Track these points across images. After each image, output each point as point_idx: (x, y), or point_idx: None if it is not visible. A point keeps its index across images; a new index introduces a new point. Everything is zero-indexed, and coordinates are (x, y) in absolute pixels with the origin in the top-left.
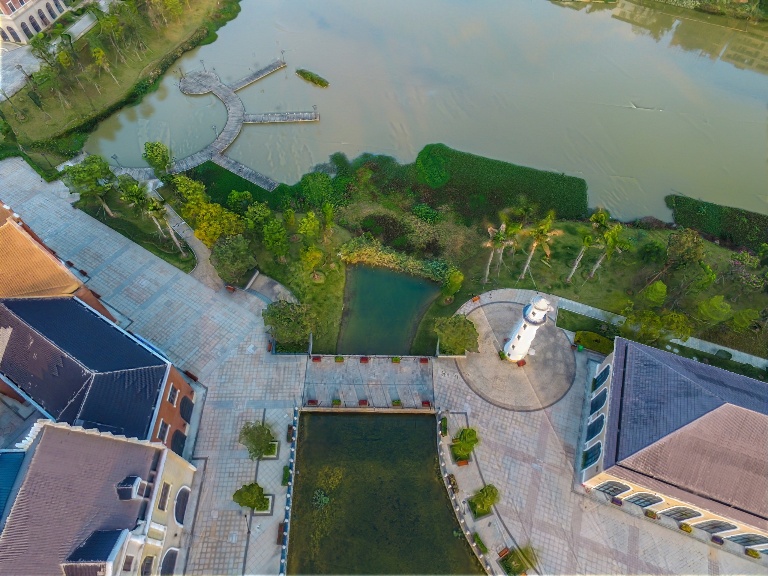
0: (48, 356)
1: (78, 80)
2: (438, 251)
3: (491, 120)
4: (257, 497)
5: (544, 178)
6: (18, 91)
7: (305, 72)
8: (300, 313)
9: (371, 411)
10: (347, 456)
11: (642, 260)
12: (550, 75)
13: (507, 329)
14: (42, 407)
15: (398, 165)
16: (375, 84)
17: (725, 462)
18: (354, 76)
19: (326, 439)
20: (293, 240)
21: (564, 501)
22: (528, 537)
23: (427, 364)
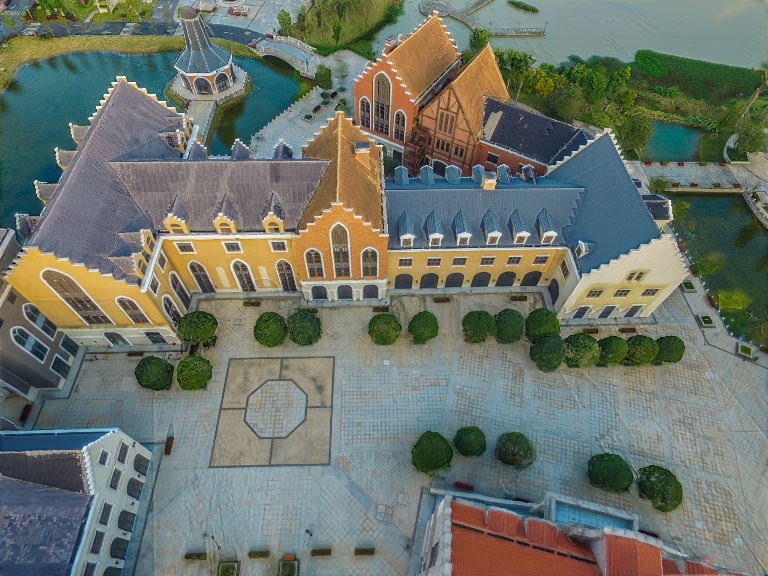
0: (539, 124)
1: (351, 2)
2: (683, 114)
3: (678, 35)
4: None
5: (739, 71)
6: (309, 9)
7: (517, 2)
8: (648, 124)
9: (700, 191)
10: (693, 215)
11: None
12: (710, 6)
13: None
14: (533, 159)
15: (623, 63)
16: (575, 11)
17: None
18: (556, 5)
19: None
20: None
21: None
22: None
23: (724, 167)
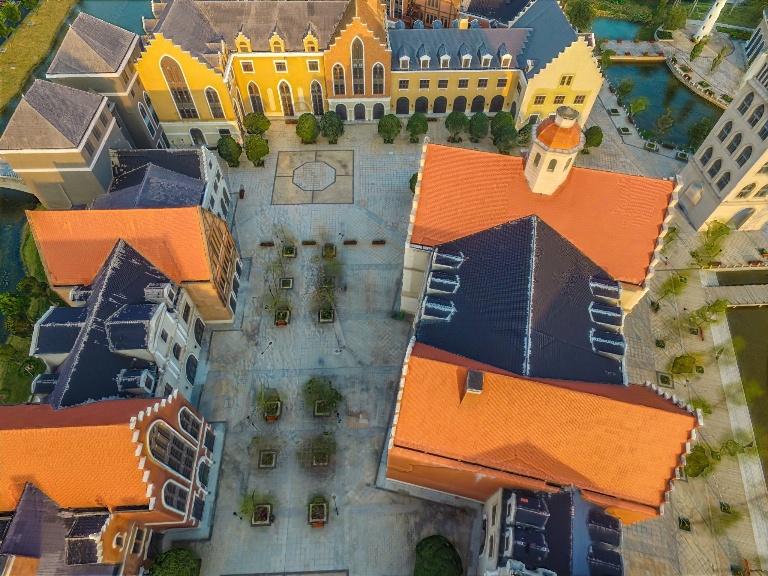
0: None
1: None
2: None
3: None
4: (610, 59)
5: None
6: None
7: None
8: (592, 7)
9: (632, 58)
10: (626, 75)
11: (760, 1)
12: None
13: (691, 33)
14: (499, 22)
15: None
16: None
17: None
18: None
19: (611, 70)
20: None
21: None
22: (732, 92)
23: (654, 43)
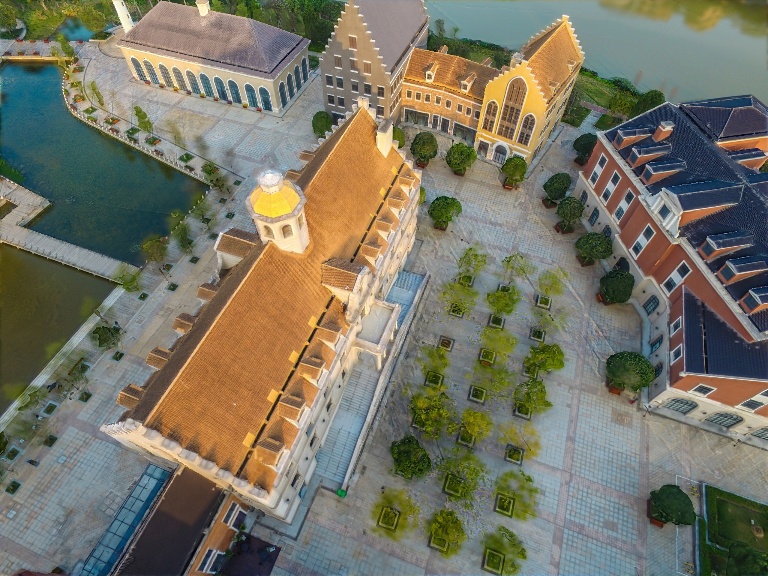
0: None
1: None
2: None
3: None
4: None
5: None
6: None
7: None
8: (2, 7)
9: (40, 58)
10: (20, 75)
11: None
12: None
13: None
14: None
15: None
16: None
17: (161, 29)
18: None
19: (12, 70)
20: (37, 4)
21: (122, 83)
22: None
23: (82, 43)
